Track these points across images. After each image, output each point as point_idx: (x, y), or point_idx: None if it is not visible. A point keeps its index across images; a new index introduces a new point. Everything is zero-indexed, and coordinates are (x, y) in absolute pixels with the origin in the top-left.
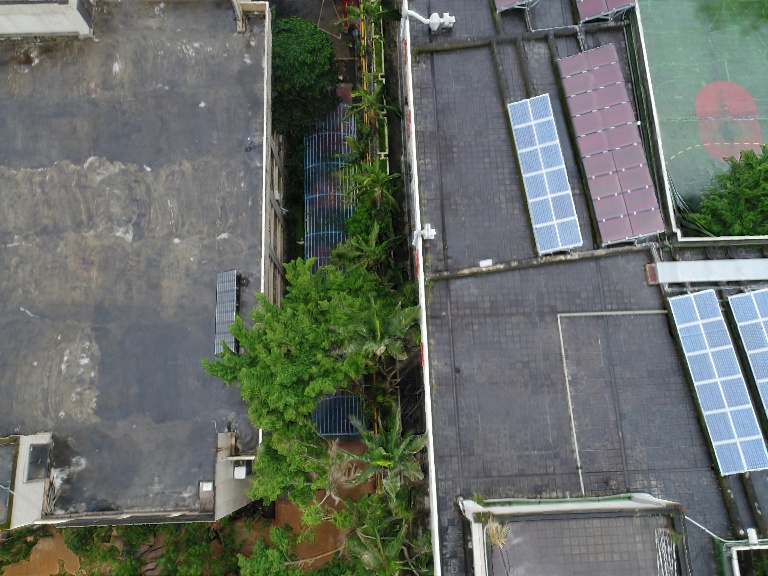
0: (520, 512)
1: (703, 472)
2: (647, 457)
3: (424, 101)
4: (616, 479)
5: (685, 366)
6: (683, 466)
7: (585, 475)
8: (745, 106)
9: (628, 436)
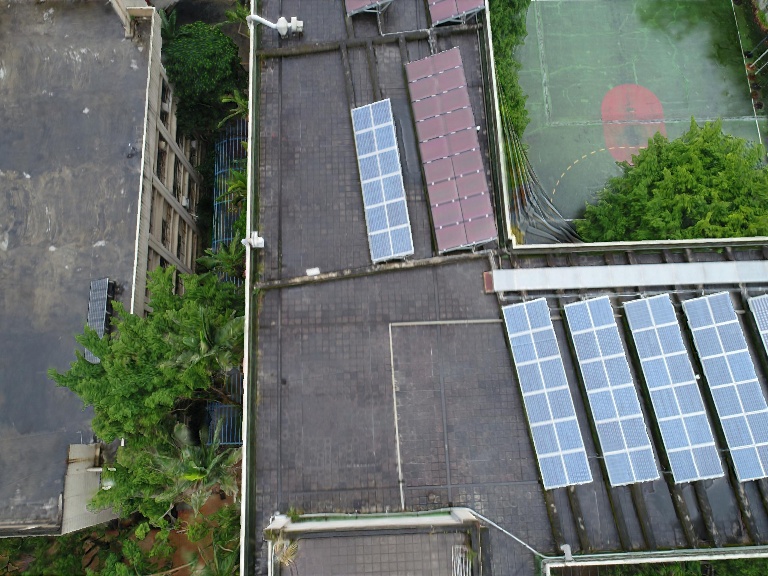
0: (312, 529)
1: (529, 486)
2: (472, 470)
3: (269, 107)
4: (439, 493)
5: (516, 376)
6: (509, 479)
7: (407, 489)
8: (652, 109)
9: (454, 449)
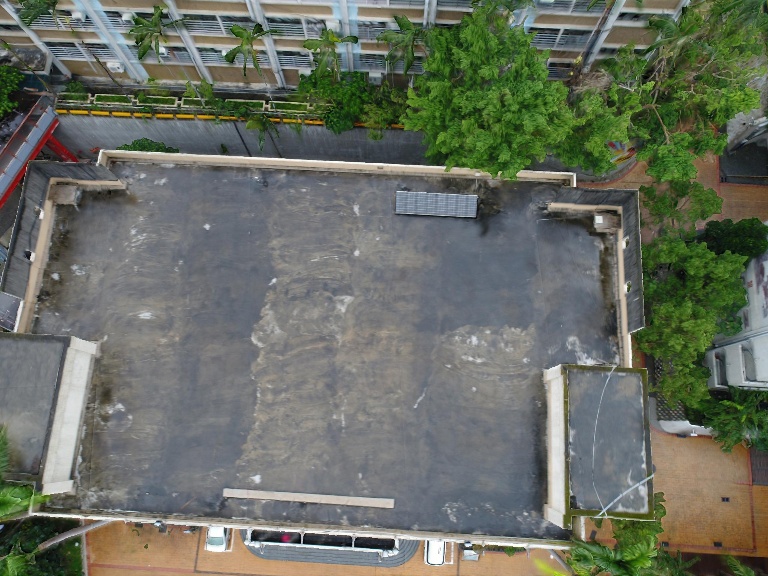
0: None
1: None
2: None
3: None
4: None
5: None
6: None
7: None
8: None
9: None
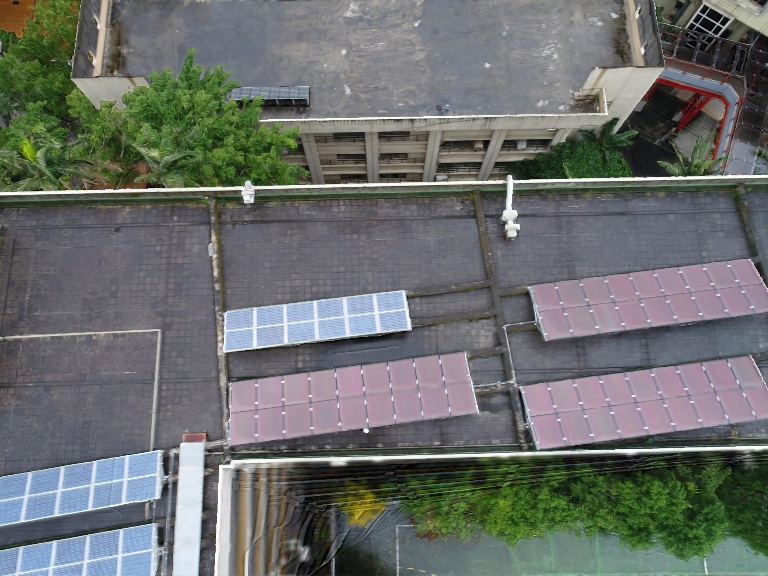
0: None
1: None
2: (3, 410)
3: (414, 207)
4: None
5: None
6: None
7: None
8: None
9: (27, 392)
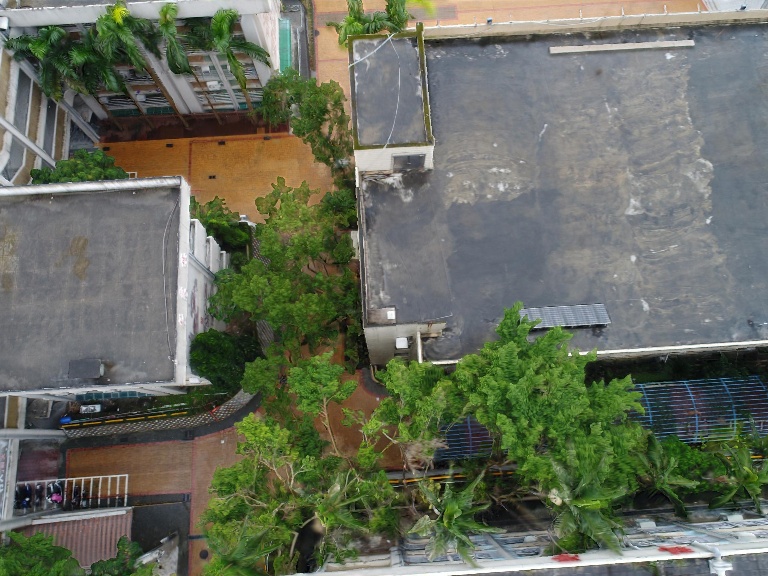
0: None
1: None
2: None
3: None
4: None
5: None
6: None
7: None
8: None
9: None
